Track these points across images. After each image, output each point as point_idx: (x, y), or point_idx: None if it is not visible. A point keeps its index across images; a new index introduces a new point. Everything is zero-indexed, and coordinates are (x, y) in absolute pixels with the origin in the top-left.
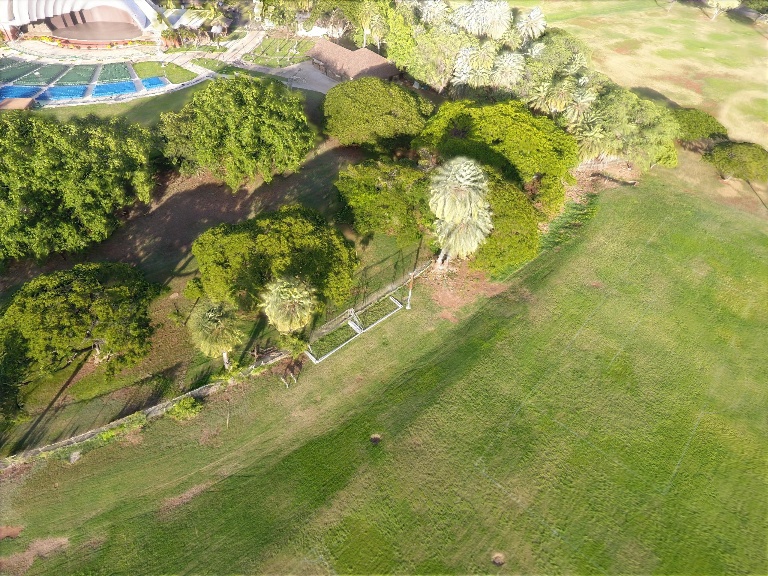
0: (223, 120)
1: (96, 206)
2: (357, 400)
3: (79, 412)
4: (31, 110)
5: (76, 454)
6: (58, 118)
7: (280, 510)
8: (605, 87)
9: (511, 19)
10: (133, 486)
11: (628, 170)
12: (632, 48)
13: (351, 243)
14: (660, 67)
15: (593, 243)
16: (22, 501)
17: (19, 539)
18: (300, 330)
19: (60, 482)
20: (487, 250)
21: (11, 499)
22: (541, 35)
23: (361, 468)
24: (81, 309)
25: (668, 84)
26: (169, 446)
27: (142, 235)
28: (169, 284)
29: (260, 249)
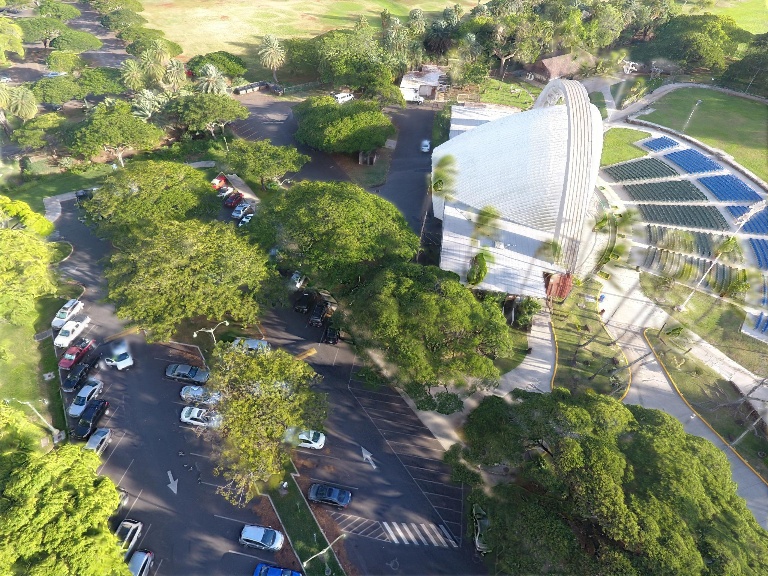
0: None
1: None
2: None
3: None
4: None
5: None
6: None
7: None
8: None
9: None
10: None
11: None
12: (465, 2)
13: None
14: None
15: None
16: None
17: None
18: None
19: None
20: None
21: None
22: None
23: None
24: None
25: None
26: None
27: None
28: None
29: None
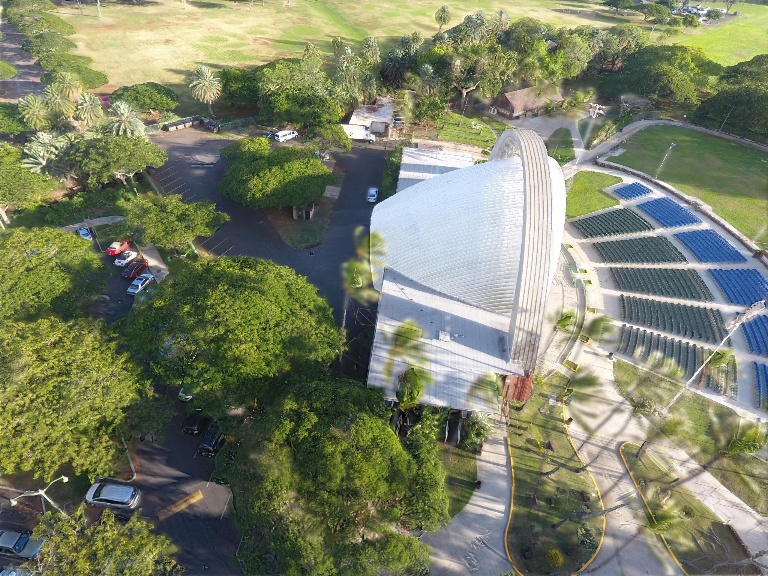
0: None
1: None
2: None
3: None
4: None
5: None
6: None
7: None
8: None
9: None
10: None
11: None
12: None
13: None
14: None
15: None
16: None
17: None
18: None
19: None
20: None
21: None
22: None
23: None
24: None
25: None
26: None
27: None
28: None
29: None
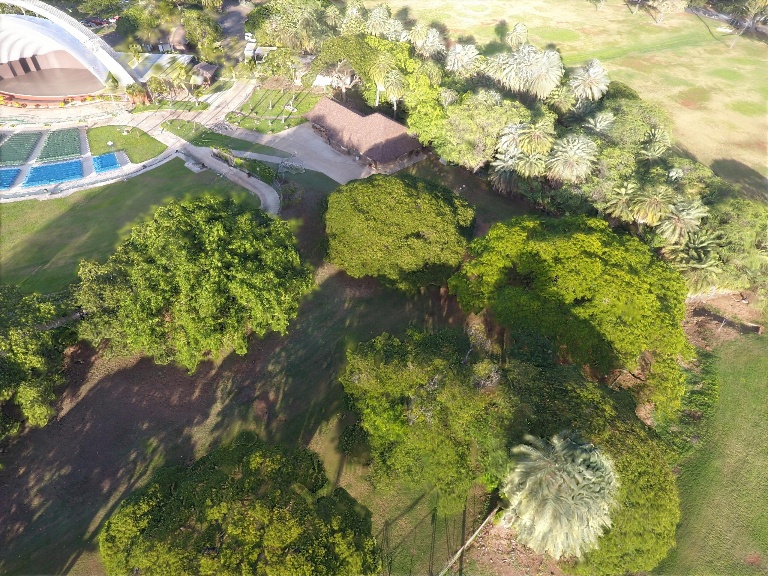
0: (172, 276)
1: None
2: None
3: None
4: None
5: None
6: None
7: None
8: (709, 186)
9: (562, 74)
10: None
11: (743, 304)
12: (700, 100)
13: (366, 522)
14: (742, 128)
15: (729, 460)
16: None
17: None
18: None
19: None
20: (600, 557)
21: None
22: (602, 96)
23: None
24: None
25: (759, 154)
26: None
27: (40, 465)
28: (71, 571)
29: None
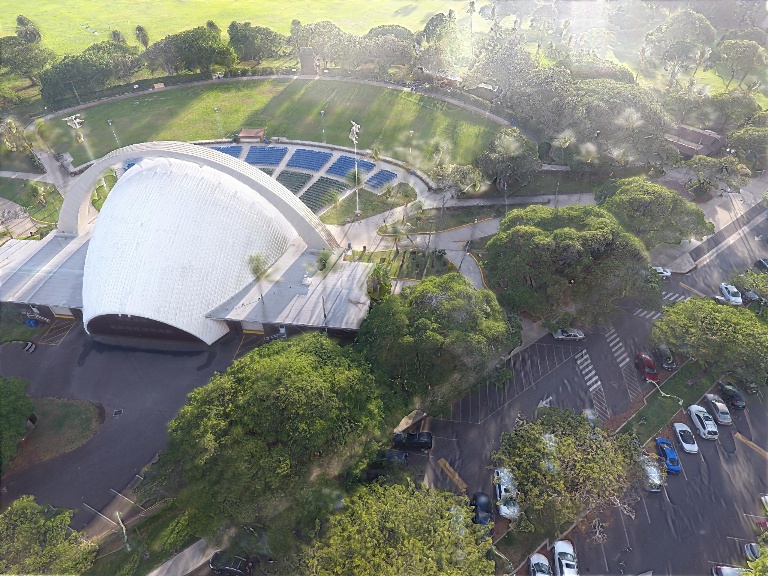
0: None
1: None
2: None
3: None
4: None
5: None
6: (216, 126)
7: None
8: None
9: None
10: None
11: None
12: None
13: None
14: None
15: None
16: None
17: None
18: None
19: None
20: None
21: None
22: None
23: None
24: None
25: None
26: None
27: None
28: None
29: None
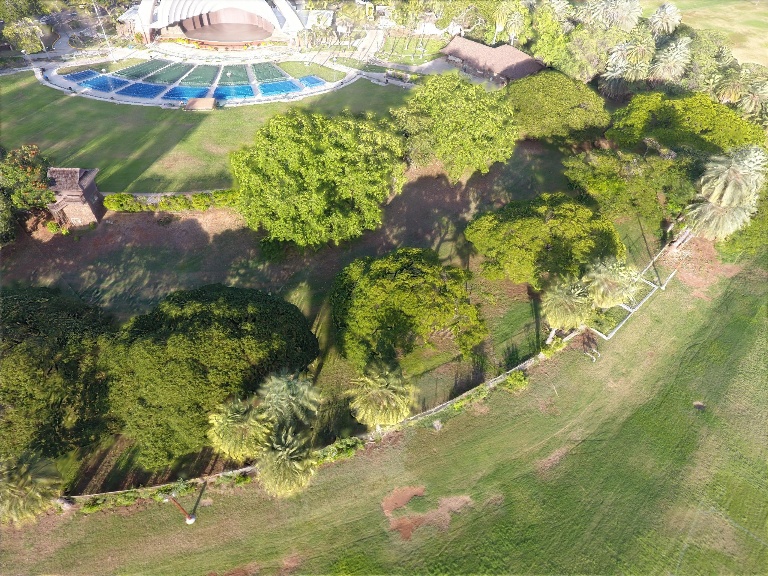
0: (453, 115)
1: (371, 197)
2: (659, 372)
3: (418, 386)
4: (217, 109)
5: (437, 423)
6: (247, 116)
7: (649, 469)
8: None
9: None
10: (502, 450)
11: None
12: (740, 41)
13: None
14: None
15: None
16: (412, 464)
17: (427, 497)
18: (598, 308)
19: (437, 447)
20: (750, 232)
21: (402, 463)
22: (675, 30)
23: (703, 431)
24: (441, 288)
25: None
26: (516, 415)
27: (389, 225)
28: None
29: (558, 233)
